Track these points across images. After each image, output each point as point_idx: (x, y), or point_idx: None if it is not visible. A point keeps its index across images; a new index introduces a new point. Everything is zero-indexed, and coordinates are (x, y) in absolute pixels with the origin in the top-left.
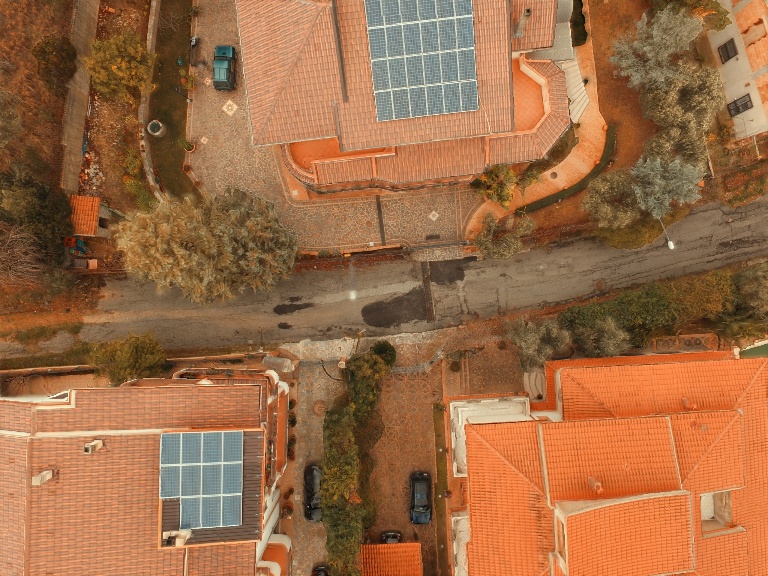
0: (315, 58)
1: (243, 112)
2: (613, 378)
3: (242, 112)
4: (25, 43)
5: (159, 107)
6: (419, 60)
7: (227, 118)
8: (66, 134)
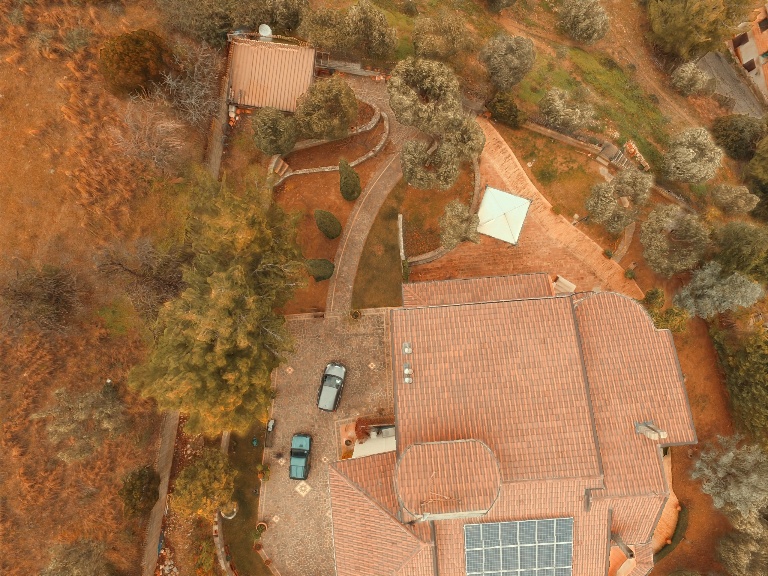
0: (412, 575)
1: (316, 493)
2: None
3: (315, 493)
4: (110, 466)
5: None
6: (515, 574)
7: (300, 498)
8: (146, 554)
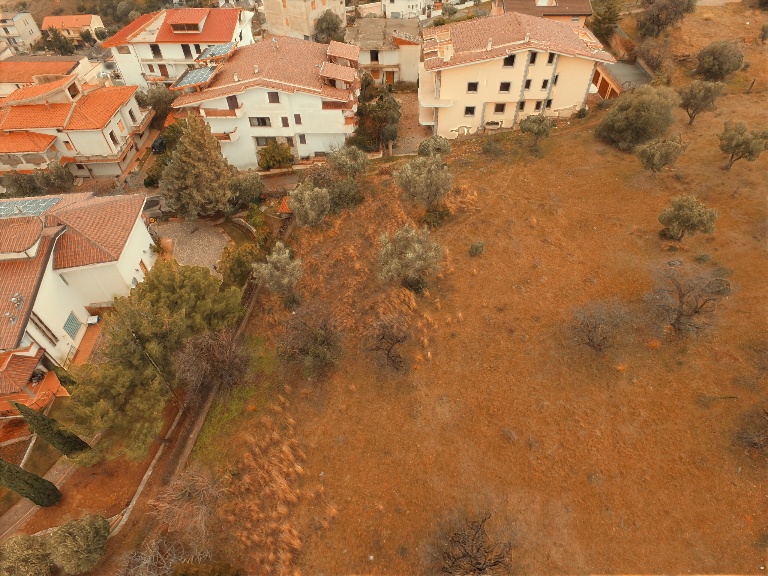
0: None
1: None
2: (18, 148)
3: None
4: None
5: (245, 277)
6: None
7: None
8: None
